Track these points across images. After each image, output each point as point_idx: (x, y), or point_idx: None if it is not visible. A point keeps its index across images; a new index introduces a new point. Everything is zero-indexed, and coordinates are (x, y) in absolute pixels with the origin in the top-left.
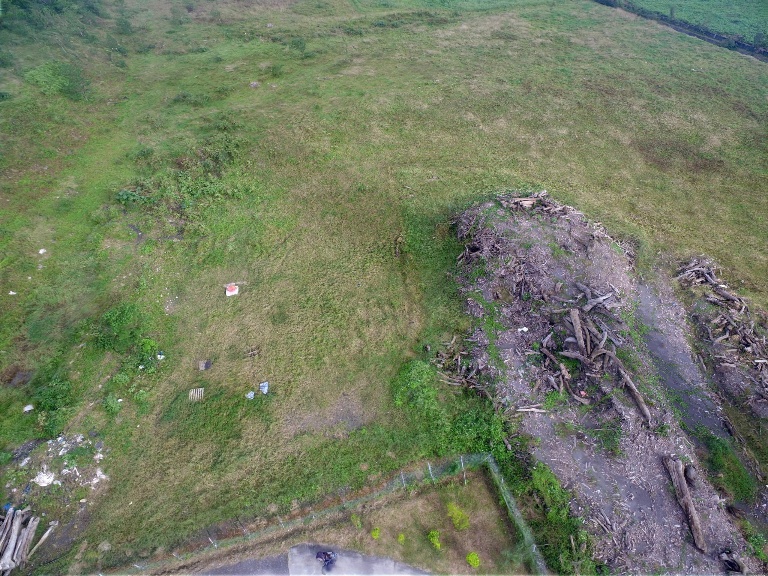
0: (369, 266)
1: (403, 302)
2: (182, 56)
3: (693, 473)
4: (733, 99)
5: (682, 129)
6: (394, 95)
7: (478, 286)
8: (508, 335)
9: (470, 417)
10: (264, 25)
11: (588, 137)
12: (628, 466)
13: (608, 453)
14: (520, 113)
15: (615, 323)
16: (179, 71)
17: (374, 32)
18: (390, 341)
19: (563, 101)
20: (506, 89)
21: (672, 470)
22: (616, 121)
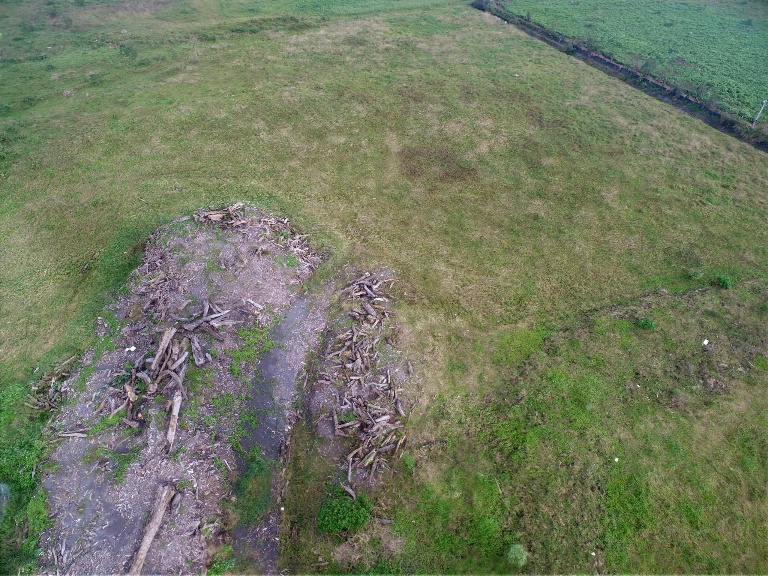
0: (46, 283)
1: (52, 321)
2: (17, 64)
3: (177, 499)
4: (533, 105)
5: (460, 136)
6: (201, 103)
7: (117, 304)
8: (114, 355)
9: (18, 443)
10: (118, 31)
11: (362, 145)
12: (121, 493)
13: (114, 479)
14: (312, 121)
15: (215, 341)
16: (1, 80)
17: (229, 38)
18: (11, 362)
19: (364, 108)
20: (317, 96)
21: (158, 496)
22: (402, 129)
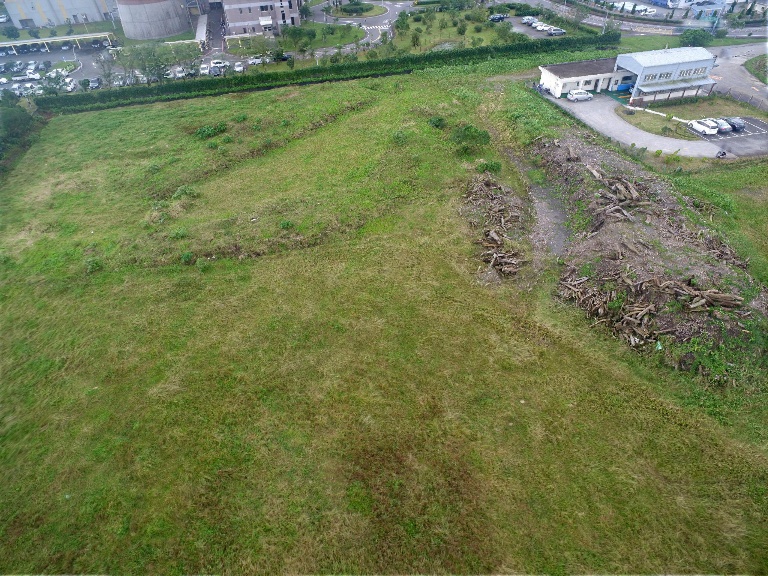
0: None
1: None
2: None
3: None
4: None
5: None
6: None
7: None
8: None
9: None
10: None
11: None
12: None
13: None
14: None
15: None
16: None
17: None
18: (760, 224)
19: None
20: None
21: None
22: None
